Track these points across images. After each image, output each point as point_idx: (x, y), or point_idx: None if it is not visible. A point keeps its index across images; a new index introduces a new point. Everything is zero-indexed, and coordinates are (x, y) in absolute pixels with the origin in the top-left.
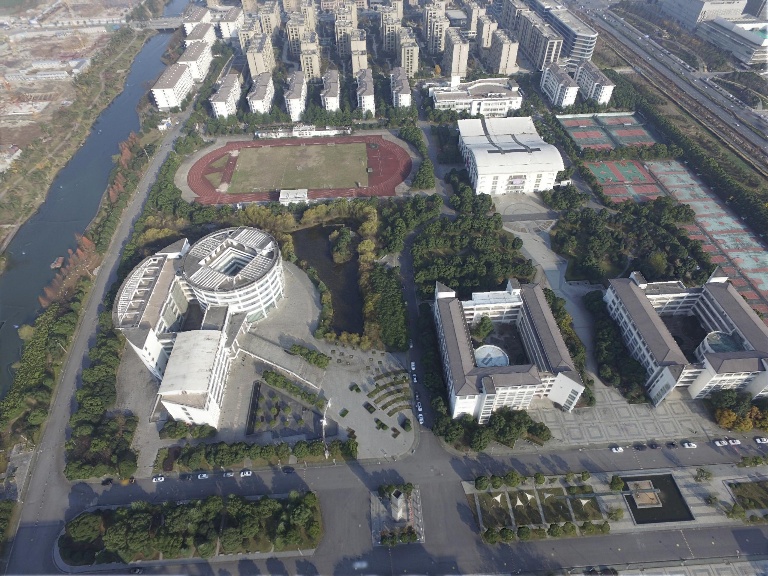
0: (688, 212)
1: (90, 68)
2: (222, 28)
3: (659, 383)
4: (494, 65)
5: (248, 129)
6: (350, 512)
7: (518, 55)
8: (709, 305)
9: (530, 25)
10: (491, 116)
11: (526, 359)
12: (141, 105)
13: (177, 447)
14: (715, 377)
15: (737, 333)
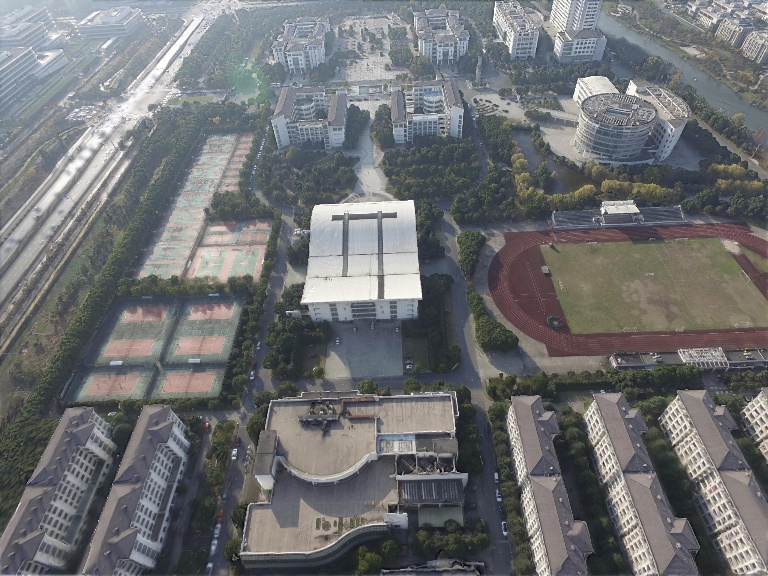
0: (220, 193)
1: None
2: None
3: None
4: None
5: None
6: None
7: None
8: None
9: None
10: None
11: None
12: None
13: None
14: (324, 92)
15: None
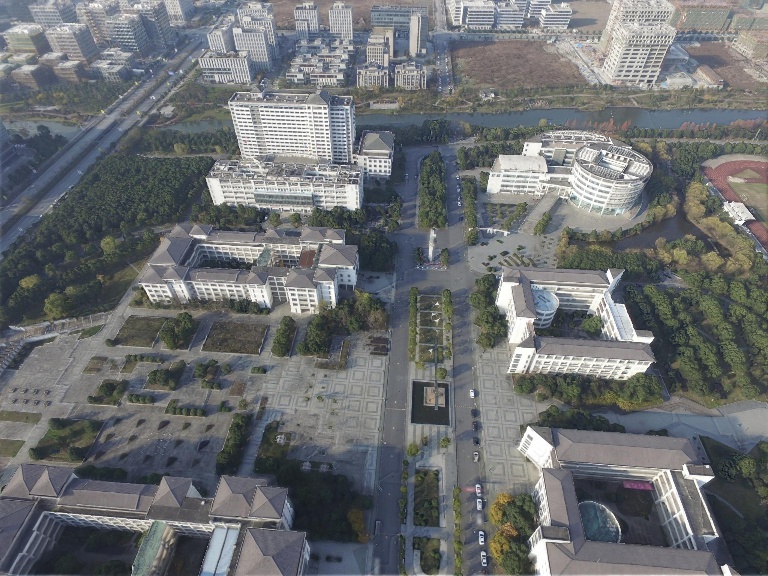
0: None
1: None
2: None
3: None
4: None
5: None
6: None
7: None
8: None
9: None
10: None
11: None
12: None
13: None
14: None
15: None
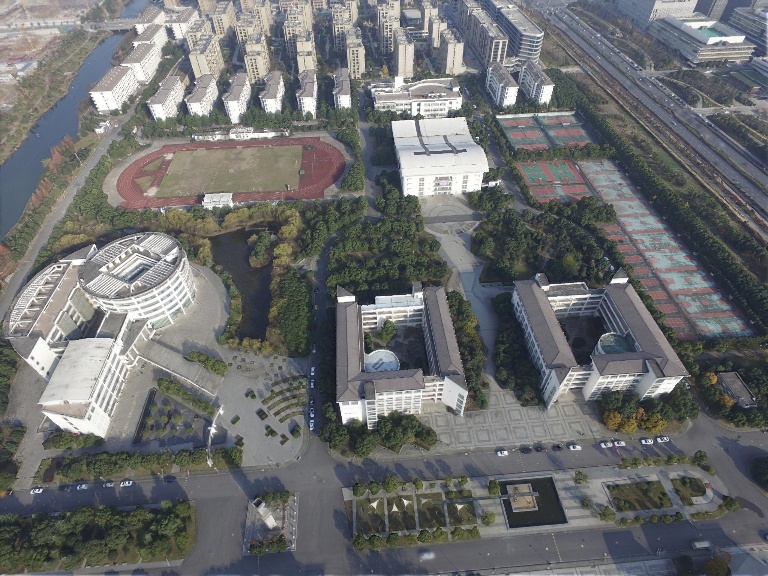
0: (609, 212)
1: (36, 71)
2: (174, 29)
3: (549, 385)
4: (442, 65)
5: (185, 132)
6: (225, 521)
7: (469, 55)
8: (609, 306)
9: (479, 25)
10: (432, 117)
11: (426, 363)
12: (81, 108)
13: (60, 457)
14: (601, 379)
15: (630, 334)
